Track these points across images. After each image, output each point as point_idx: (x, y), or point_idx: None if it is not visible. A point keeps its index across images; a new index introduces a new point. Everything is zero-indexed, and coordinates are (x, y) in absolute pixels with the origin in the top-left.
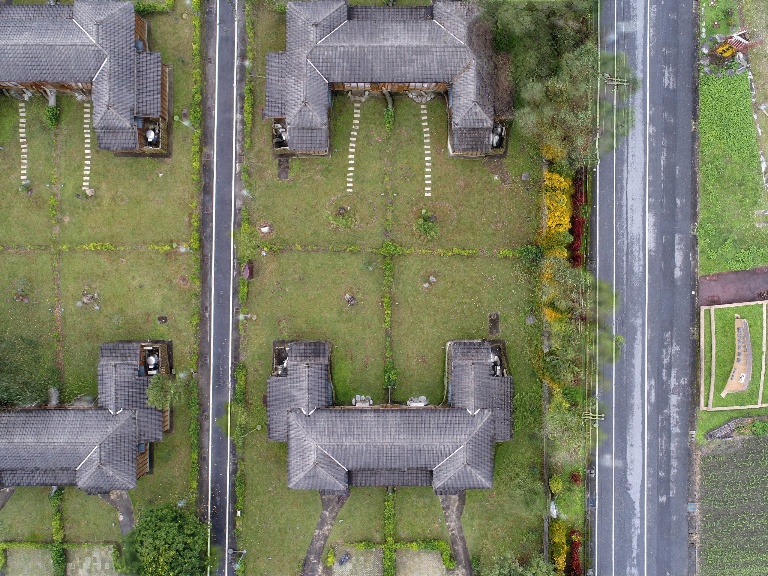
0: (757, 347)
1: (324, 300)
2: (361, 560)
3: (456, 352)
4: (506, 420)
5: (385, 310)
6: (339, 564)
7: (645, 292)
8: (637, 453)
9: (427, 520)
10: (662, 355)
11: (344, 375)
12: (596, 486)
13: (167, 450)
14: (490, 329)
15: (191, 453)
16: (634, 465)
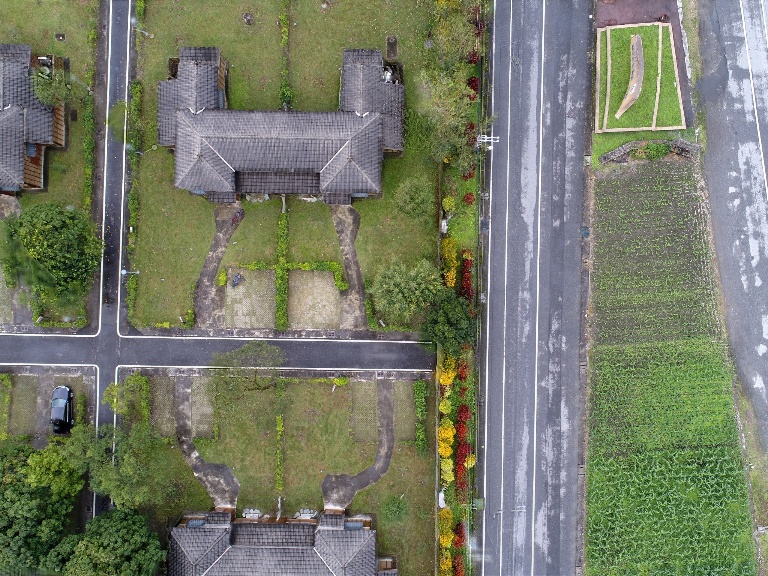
0: (652, 68)
1: (222, 20)
2: (254, 284)
3: (347, 58)
4: (396, 128)
5: (282, 27)
6: (232, 287)
7: (542, 14)
8: (531, 176)
9: (321, 243)
10: (558, 78)
11: (241, 96)
12: (490, 209)
13: (62, 168)
14: (388, 52)
15: (85, 168)
16: (528, 188)
